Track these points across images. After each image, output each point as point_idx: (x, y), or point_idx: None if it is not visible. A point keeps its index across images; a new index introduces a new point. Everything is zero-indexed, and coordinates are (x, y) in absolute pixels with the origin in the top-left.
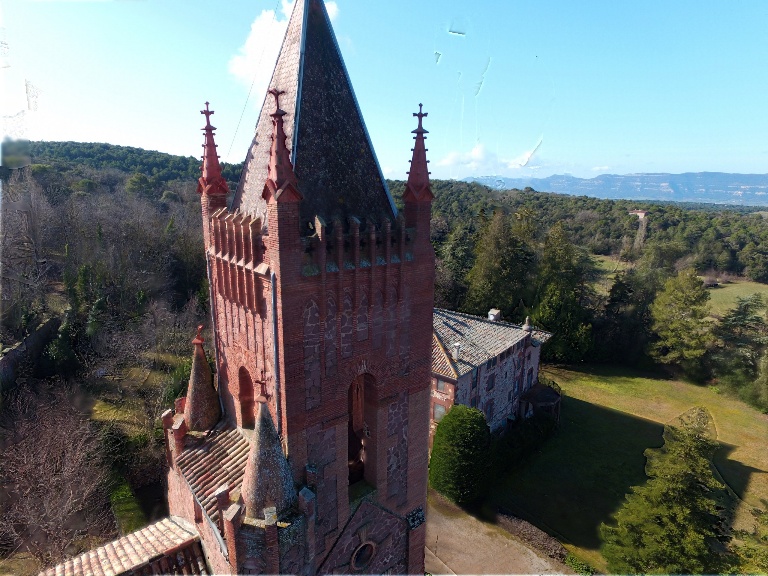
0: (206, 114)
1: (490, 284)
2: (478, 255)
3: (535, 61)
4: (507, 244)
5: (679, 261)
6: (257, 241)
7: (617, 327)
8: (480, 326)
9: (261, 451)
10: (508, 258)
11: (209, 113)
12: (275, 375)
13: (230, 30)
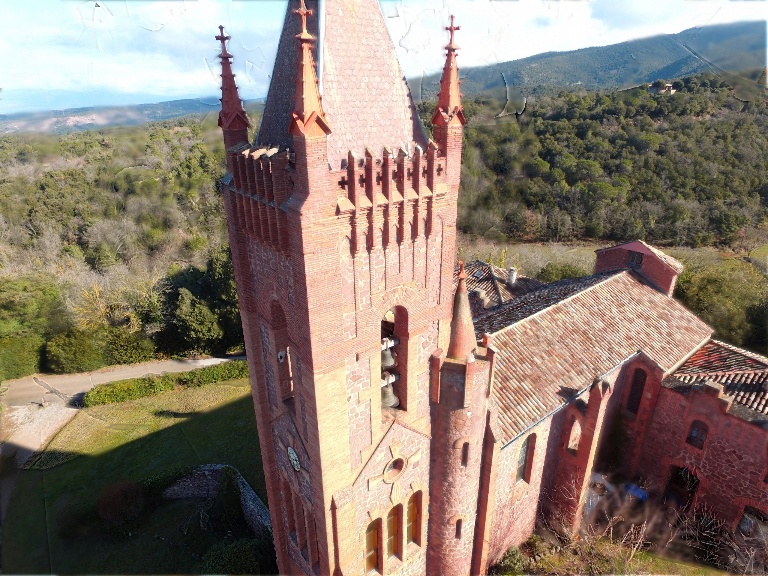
0: None
1: None
2: None
3: None
4: None
5: None
6: None
7: None
8: None
9: None
10: None
11: (450, 29)
12: None
13: None
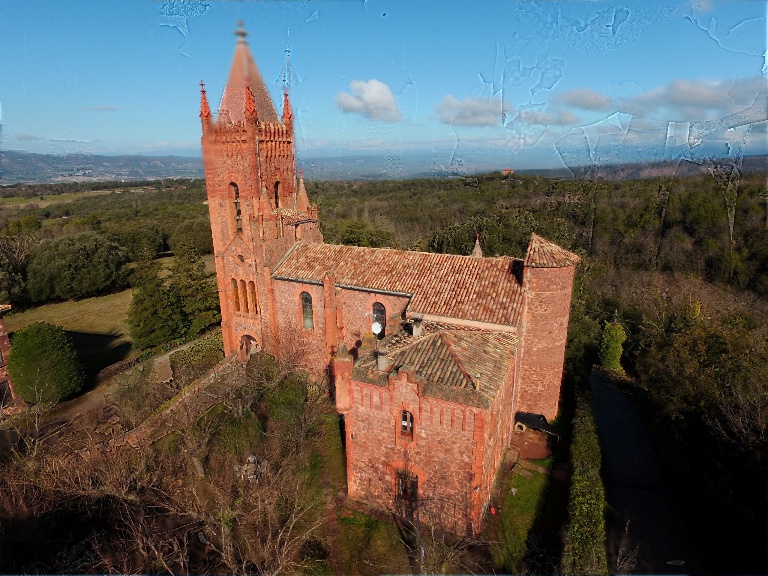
0: None
1: None
2: None
3: None
4: None
5: None
6: None
7: None
8: None
9: None
10: None
11: None
12: None
13: None
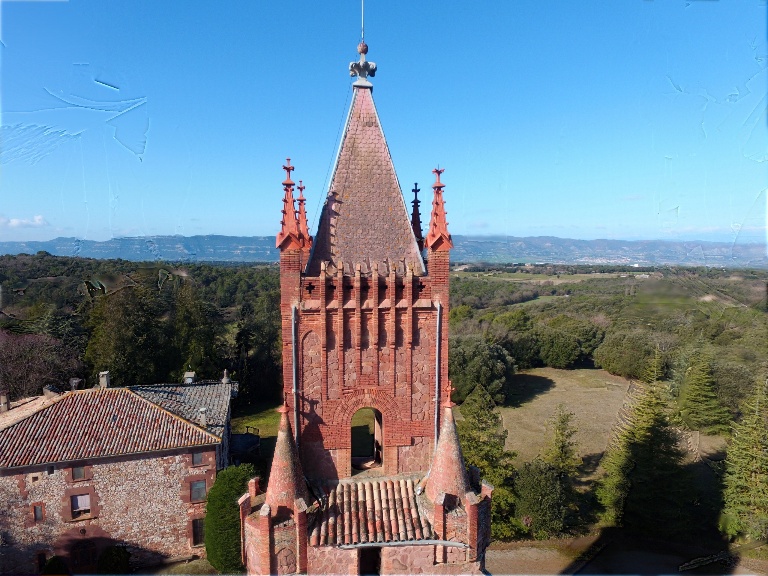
0: (289, 170)
1: (124, 356)
2: (94, 327)
3: (176, 129)
4: (137, 309)
5: None
6: (414, 282)
7: (251, 369)
8: (189, 391)
9: (459, 446)
10: (141, 324)
11: (291, 169)
12: (437, 388)
13: (80, 50)
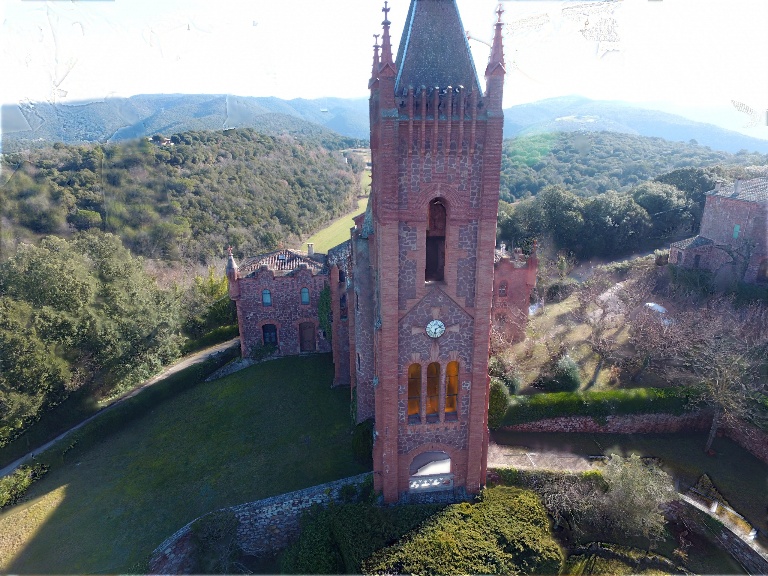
0: None
1: None
2: None
3: None
4: None
5: None
6: None
7: None
8: None
9: None
10: None
11: None
12: None
13: None
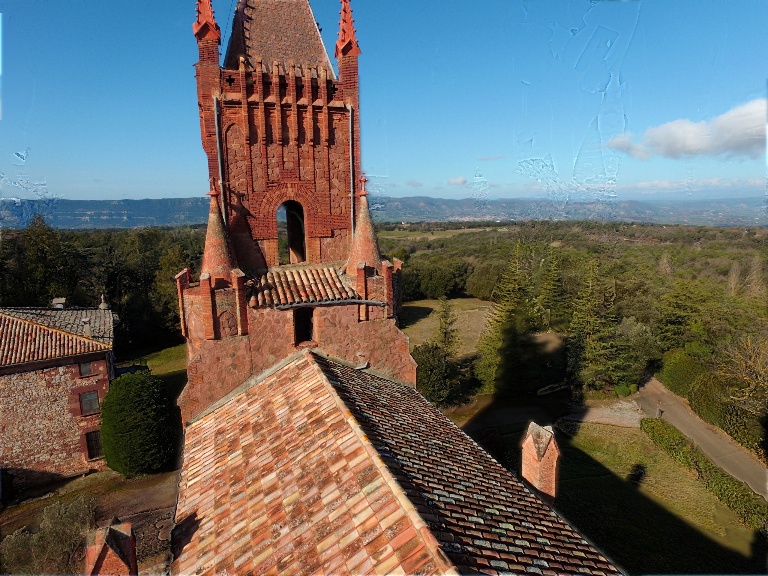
0: None
1: None
2: None
3: (7, 21)
4: None
5: (161, 243)
6: (328, 83)
7: None
8: (62, 314)
9: None
10: None
11: None
12: (352, 183)
13: None
